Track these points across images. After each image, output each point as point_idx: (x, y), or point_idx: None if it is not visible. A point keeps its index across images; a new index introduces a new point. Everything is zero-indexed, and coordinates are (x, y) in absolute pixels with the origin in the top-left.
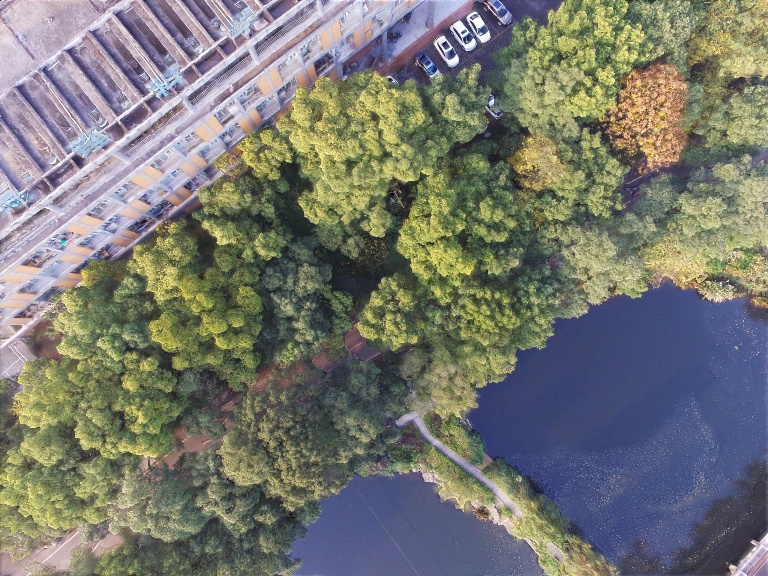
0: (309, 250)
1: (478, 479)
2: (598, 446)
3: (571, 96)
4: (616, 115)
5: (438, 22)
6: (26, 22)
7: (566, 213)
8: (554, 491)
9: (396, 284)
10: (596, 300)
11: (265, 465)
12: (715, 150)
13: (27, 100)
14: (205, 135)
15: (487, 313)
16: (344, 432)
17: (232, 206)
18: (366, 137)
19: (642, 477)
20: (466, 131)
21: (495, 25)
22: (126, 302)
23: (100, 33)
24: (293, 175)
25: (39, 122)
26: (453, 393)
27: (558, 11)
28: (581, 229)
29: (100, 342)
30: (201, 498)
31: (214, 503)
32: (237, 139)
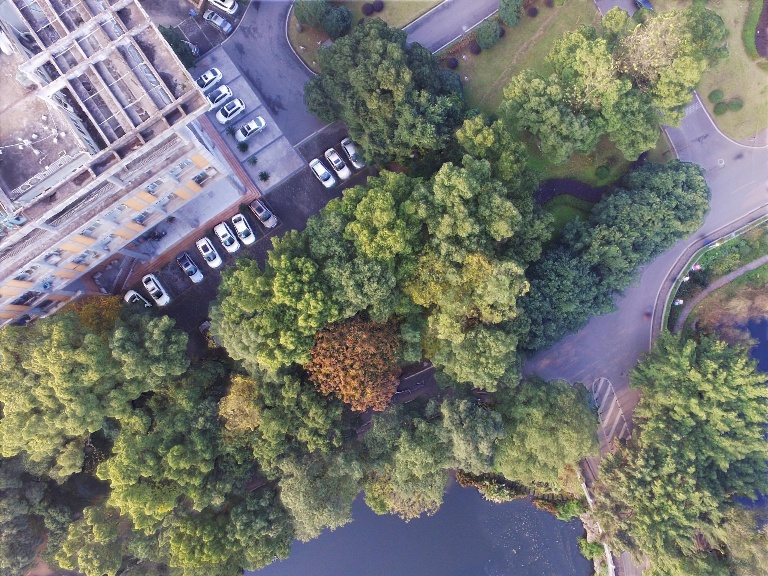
0: (9, 478)
1: None
2: None
3: (261, 352)
4: None
5: (204, 221)
6: None
7: (270, 455)
8: None
9: (90, 520)
10: None
11: None
12: (455, 379)
13: None
14: None
15: None
16: None
17: None
18: (37, 393)
19: None
20: (155, 380)
21: (262, 226)
22: None
23: None
24: None
25: None
26: None
27: None
28: (295, 465)
29: None
30: None
31: None
32: None
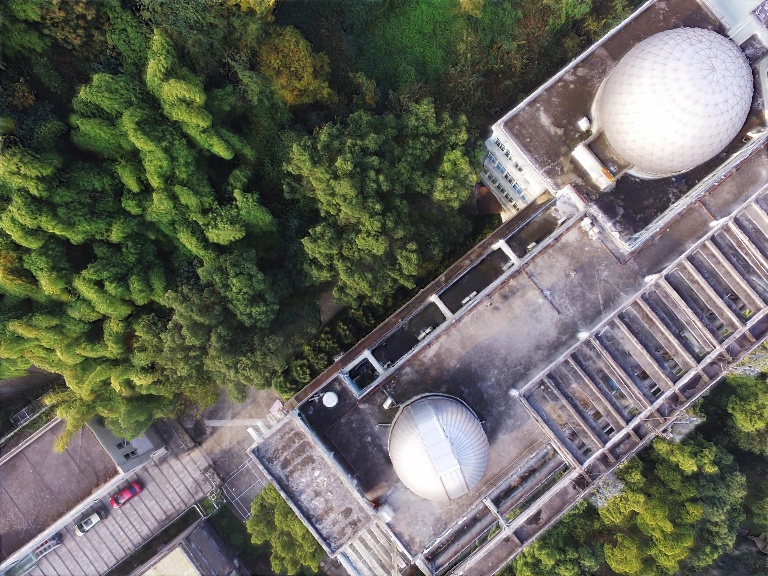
0: None
1: None
2: None
3: None
4: None
5: None
6: (548, 275)
7: None
8: None
9: None
10: None
11: None
12: None
13: (581, 368)
14: None
15: None
16: None
17: None
18: None
19: None
20: None
21: None
22: (572, 521)
23: (647, 296)
24: None
25: (595, 391)
26: None
27: None
28: None
29: (565, 571)
30: None
31: None
32: None
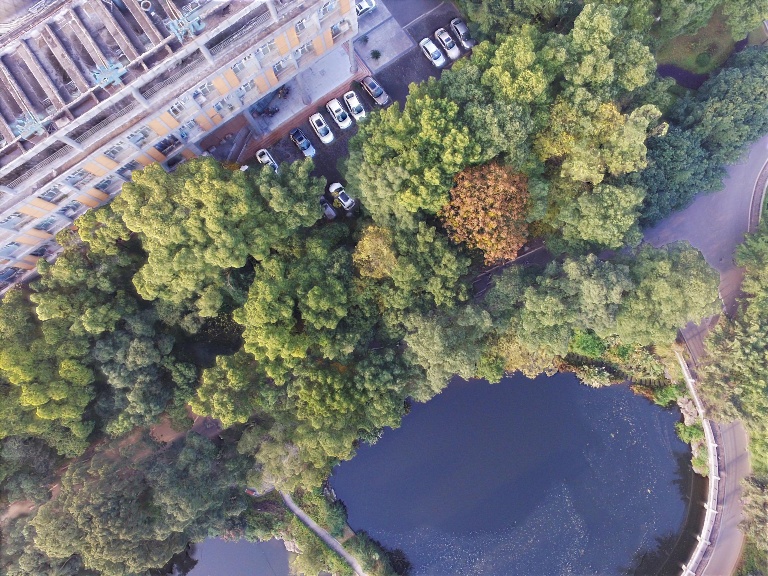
0: (145, 324)
1: (338, 552)
2: (464, 527)
3: (401, 192)
4: (450, 211)
5: (316, 99)
6: None
7: (402, 303)
8: (415, 570)
9: (226, 364)
10: (436, 389)
11: (74, 540)
12: (573, 243)
13: None
14: (35, 213)
15: (317, 398)
16: (165, 509)
17: (65, 280)
18: (188, 224)
19: (507, 563)
20: (297, 220)
21: (372, 104)
22: None
23: None
24: (136, 249)
25: None
26: (285, 474)
27: (387, 111)
28: (422, 318)
29: None
30: (10, 568)
31: (25, 573)
32: (83, 212)
